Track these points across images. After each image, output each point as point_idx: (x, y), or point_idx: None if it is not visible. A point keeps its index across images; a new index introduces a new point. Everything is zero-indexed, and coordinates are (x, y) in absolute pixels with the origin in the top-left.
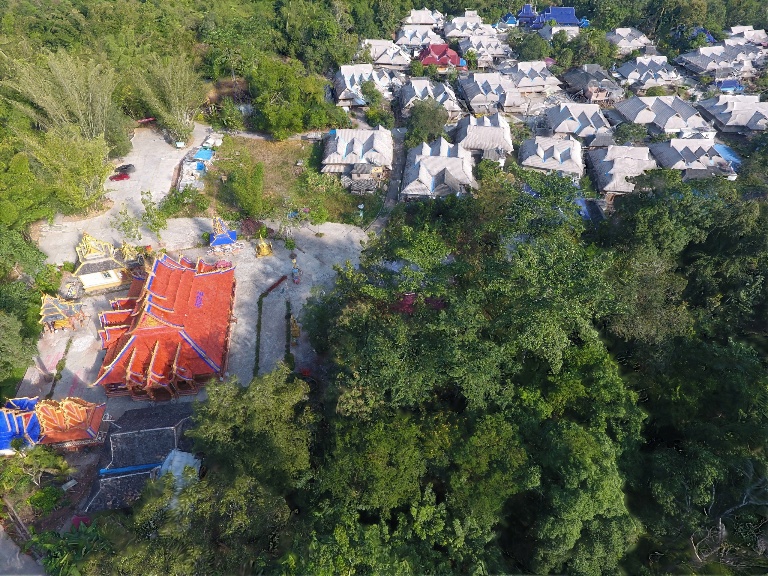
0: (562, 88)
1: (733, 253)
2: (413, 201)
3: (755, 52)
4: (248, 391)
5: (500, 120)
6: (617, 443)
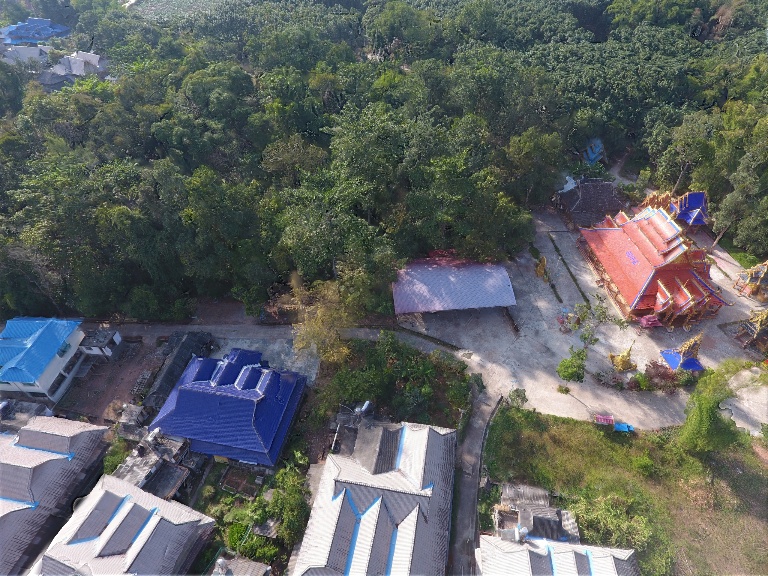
0: None
1: None
2: None
3: None
4: None
5: None
6: None
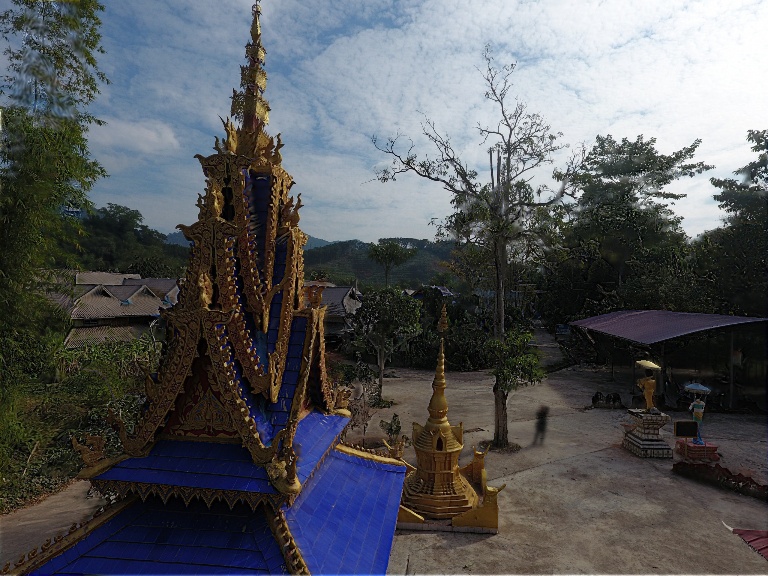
0: None
1: None
2: None
3: None
4: None
5: None
6: None
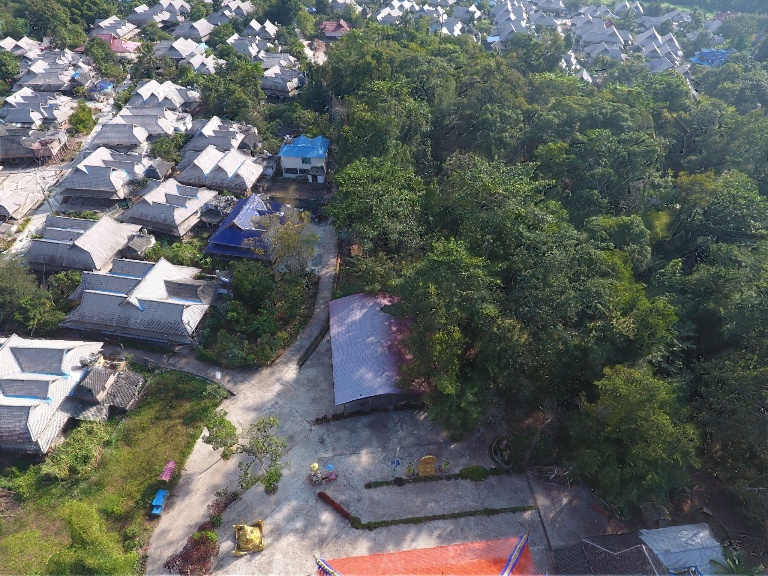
0: (1, 165)
1: (408, 141)
2: (203, 329)
3: (62, 55)
4: (652, 397)
5: (71, 218)
6: (572, 226)
